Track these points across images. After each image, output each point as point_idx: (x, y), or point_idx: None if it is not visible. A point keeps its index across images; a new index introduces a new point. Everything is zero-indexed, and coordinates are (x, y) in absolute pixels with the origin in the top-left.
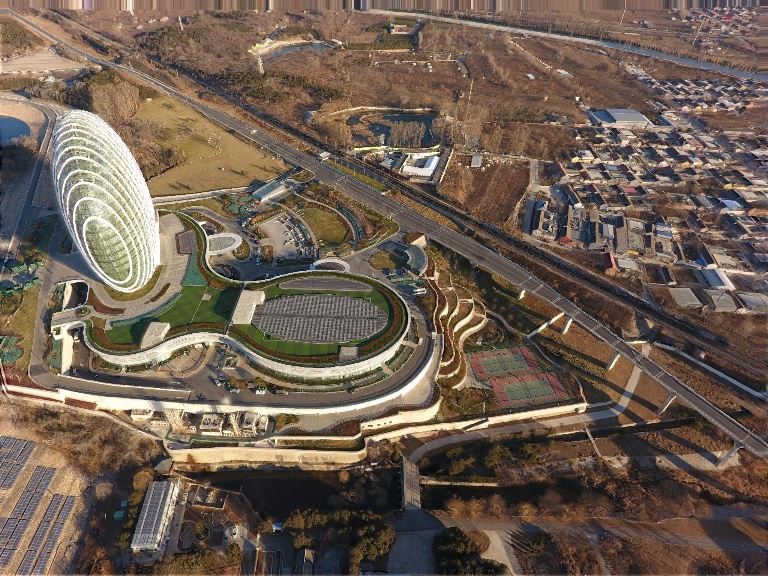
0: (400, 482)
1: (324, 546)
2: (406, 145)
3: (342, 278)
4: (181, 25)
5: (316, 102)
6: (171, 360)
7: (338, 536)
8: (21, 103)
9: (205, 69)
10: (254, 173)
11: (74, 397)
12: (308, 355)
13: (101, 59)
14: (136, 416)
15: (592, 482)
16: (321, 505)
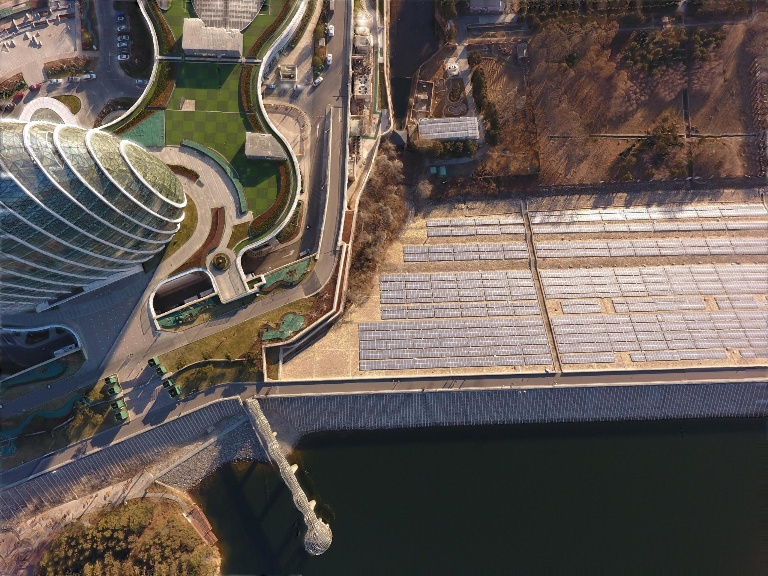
0: None
1: None
2: None
3: None
4: None
5: None
6: None
7: None
8: None
9: None
10: None
11: None
12: None
13: None
14: None
15: None
16: (423, 2)
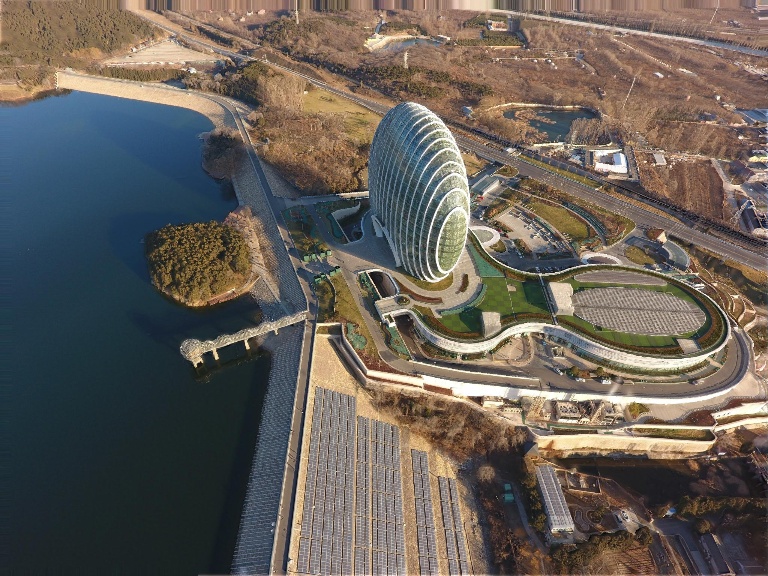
0: (753, 472)
1: (721, 531)
2: (583, 142)
3: (631, 272)
4: (297, 18)
5: (465, 97)
6: (498, 349)
7: (737, 522)
8: (191, 94)
9: (343, 63)
10: None
11: (431, 383)
12: (650, 346)
13: (230, 51)
14: (489, 403)
15: None
16: (686, 492)
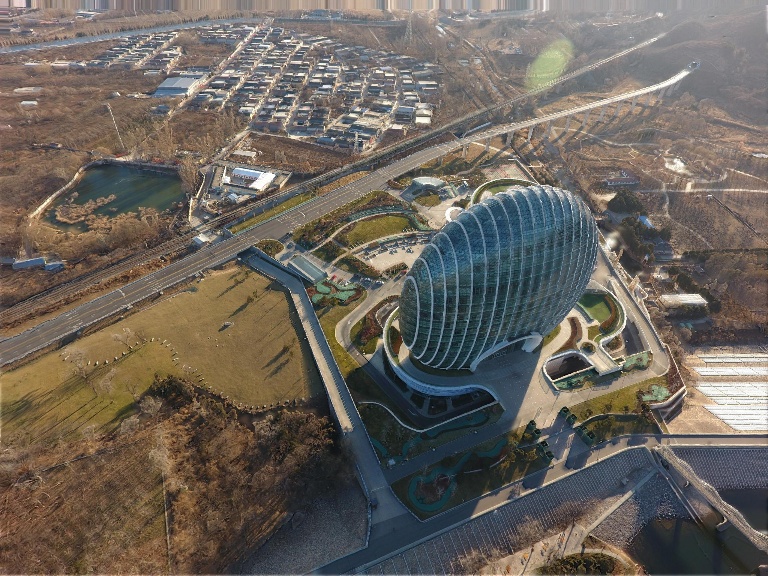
0: None
1: None
2: (195, 185)
3: None
4: None
5: None
6: None
7: None
8: None
9: None
10: (247, 291)
11: None
12: None
13: None
14: None
15: (554, 173)
16: None
